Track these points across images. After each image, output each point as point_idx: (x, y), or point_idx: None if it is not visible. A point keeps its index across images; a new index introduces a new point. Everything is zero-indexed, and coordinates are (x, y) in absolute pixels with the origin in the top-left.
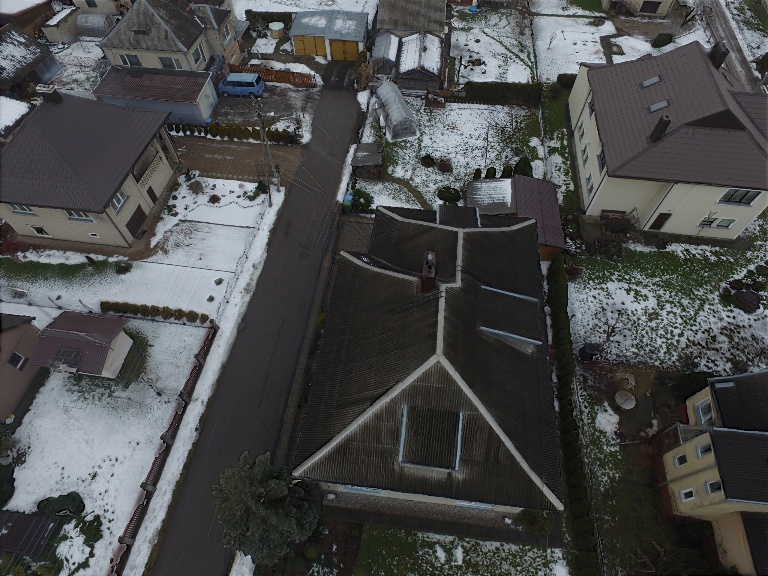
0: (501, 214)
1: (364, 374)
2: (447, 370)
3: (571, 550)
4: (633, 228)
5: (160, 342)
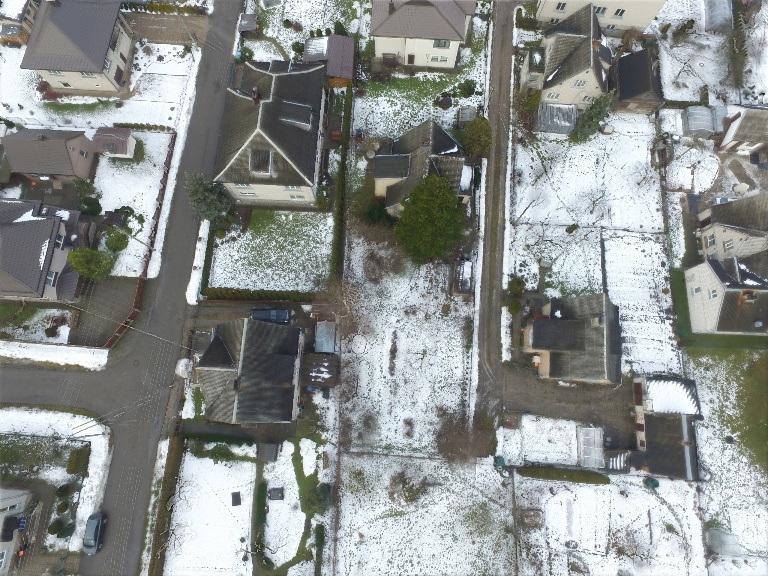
0: (320, 60)
1: (236, 141)
2: (262, 135)
3: (336, 213)
4: (399, 64)
5: (149, 142)
